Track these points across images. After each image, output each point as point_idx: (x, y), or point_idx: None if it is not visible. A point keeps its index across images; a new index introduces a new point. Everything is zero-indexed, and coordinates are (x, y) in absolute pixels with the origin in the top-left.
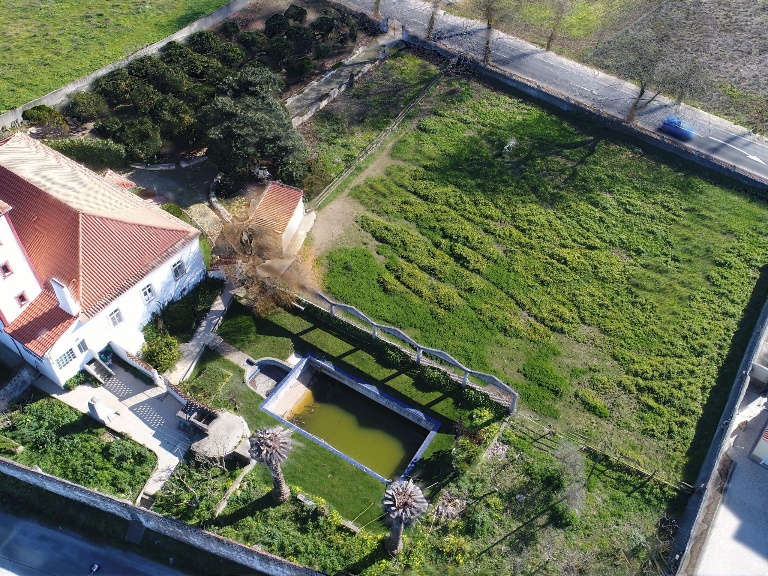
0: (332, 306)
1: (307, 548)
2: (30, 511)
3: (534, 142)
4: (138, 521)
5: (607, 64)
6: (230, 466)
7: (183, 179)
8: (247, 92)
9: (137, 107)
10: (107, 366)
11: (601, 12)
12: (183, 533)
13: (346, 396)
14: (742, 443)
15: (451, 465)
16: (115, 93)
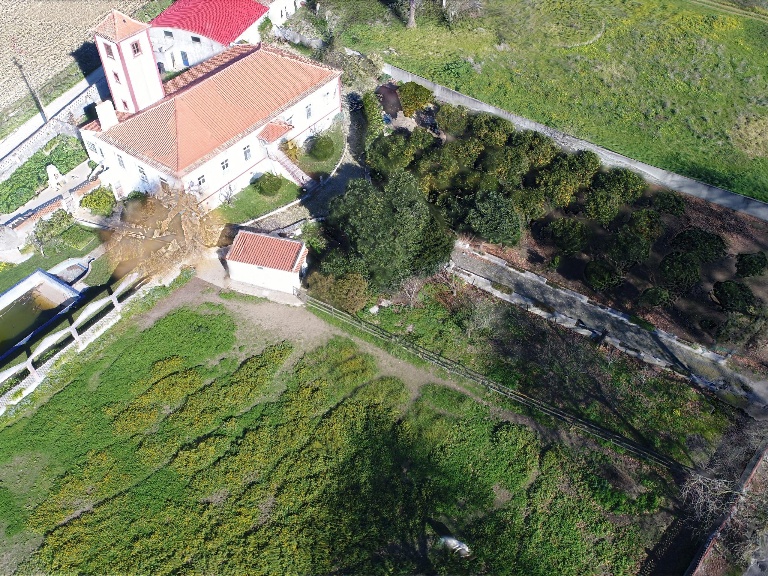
0: None
1: None
2: None
3: None
4: None
5: None
6: None
7: None
8: None
9: None
10: None
11: None
12: None
13: None
14: None
15: None
16: None
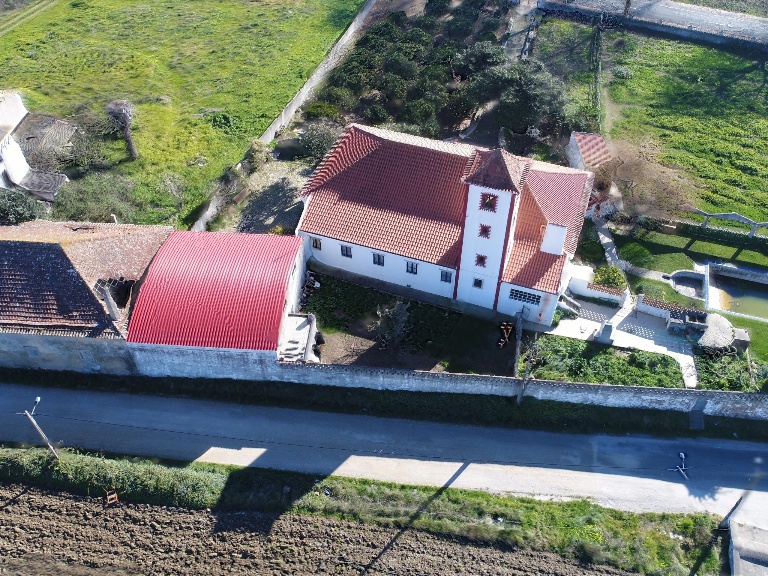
0: None
1: None
2: (595, 427)
3: (717, 72)
4: (695, 410)
5: (715, 3)
6: (739, 351)
7: None
8: (485, 64)
9: (393, 93)
10: (572, 300)
11: None
12: (751, 406)
13: (750, 289)
14: None
15: None
16: (359, 85)
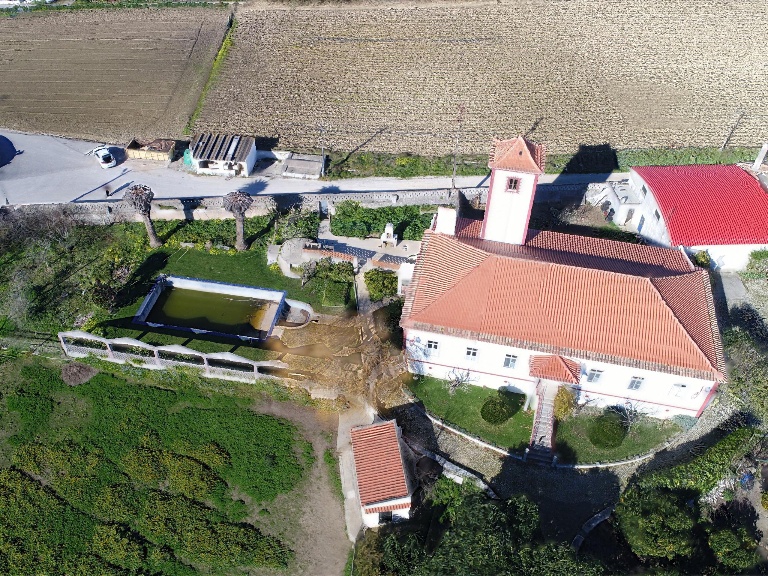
0: None
1: (213, 227)
2: None
3: None
4: None
5: None
6: None
7: (555, 513)
8: None
9: None
10: None
11: None
12: None
13: None
14: None
15: None
16: None
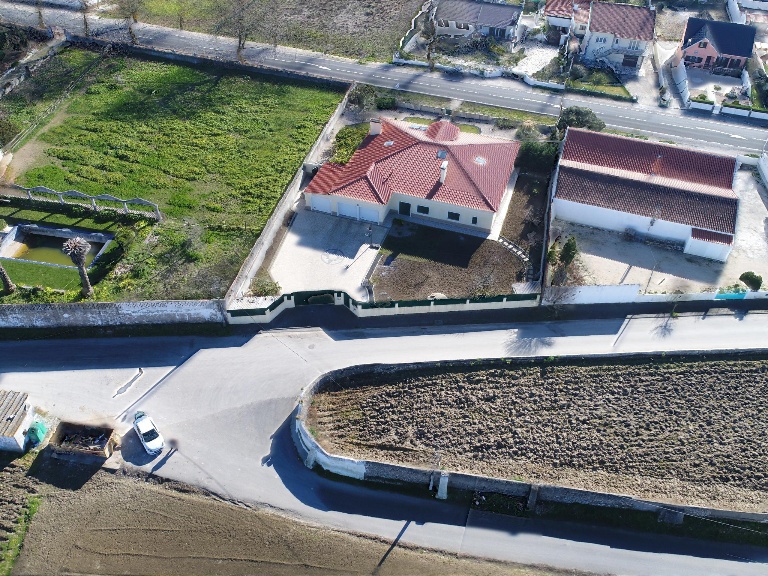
0: (28, 191)
1: None
2: None
3: (174, 86)
4: None
5: (228, 32)
6: None
7: None
8: None
9: None
10: None
11: (224, 0)
12: None
13: (51, 242)
14: (302, 204)
15: (122, 251)
16: None
